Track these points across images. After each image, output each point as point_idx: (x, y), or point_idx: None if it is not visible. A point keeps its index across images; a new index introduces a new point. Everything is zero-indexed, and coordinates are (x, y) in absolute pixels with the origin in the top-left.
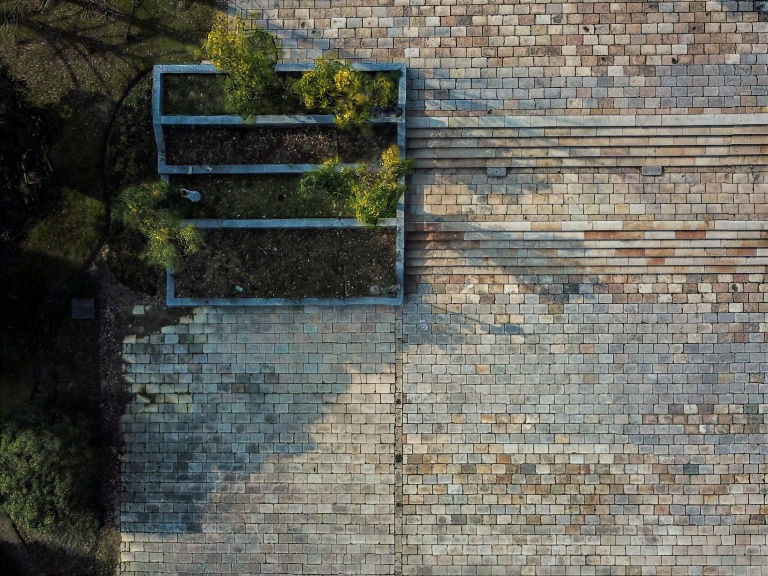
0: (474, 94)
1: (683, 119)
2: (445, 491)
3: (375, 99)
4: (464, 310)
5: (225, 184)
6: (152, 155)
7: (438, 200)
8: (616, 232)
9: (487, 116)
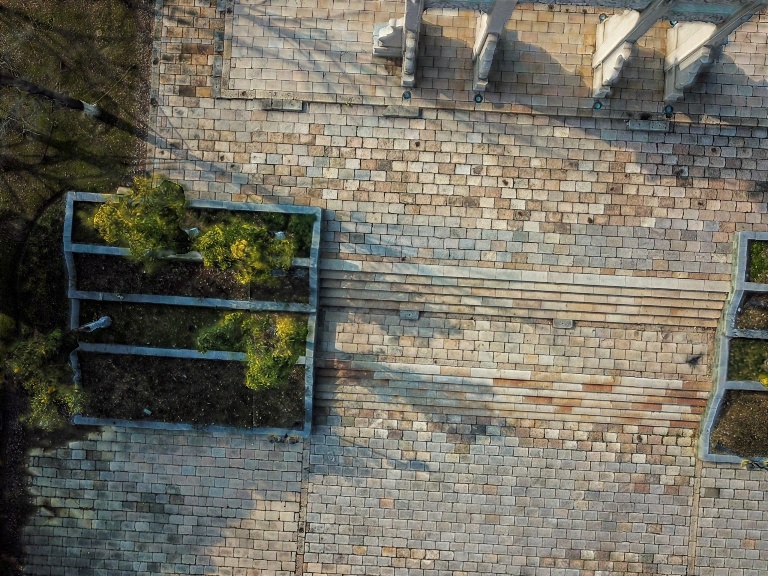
0: (389, 240)
1: (595, 279)
2: None
3: (278, 260)
4: (372, 444)
5: (137, 311)
6: (64, 278)
7: (350, 338)
8: (524, 381)
9: (401, 263)
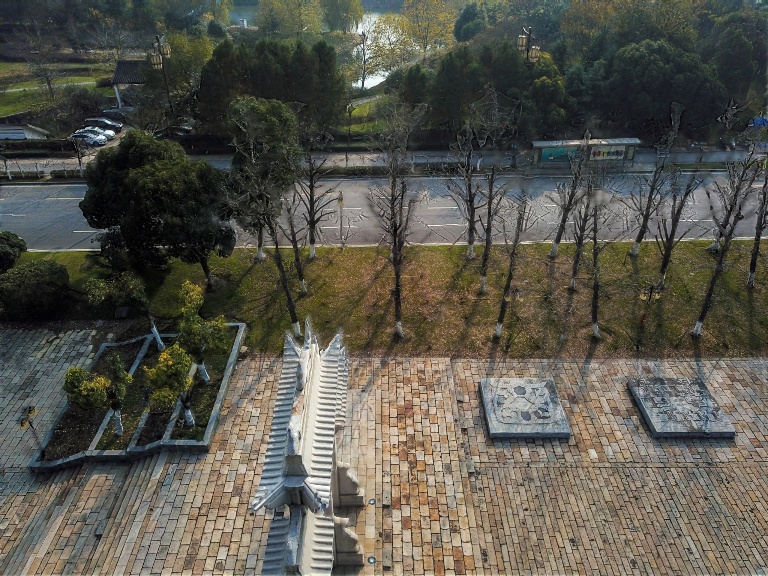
0: (171, 497)
1: None
2: None
3: None
4: None
5: None
6: None
7: None
8: None
9: (149, 508)
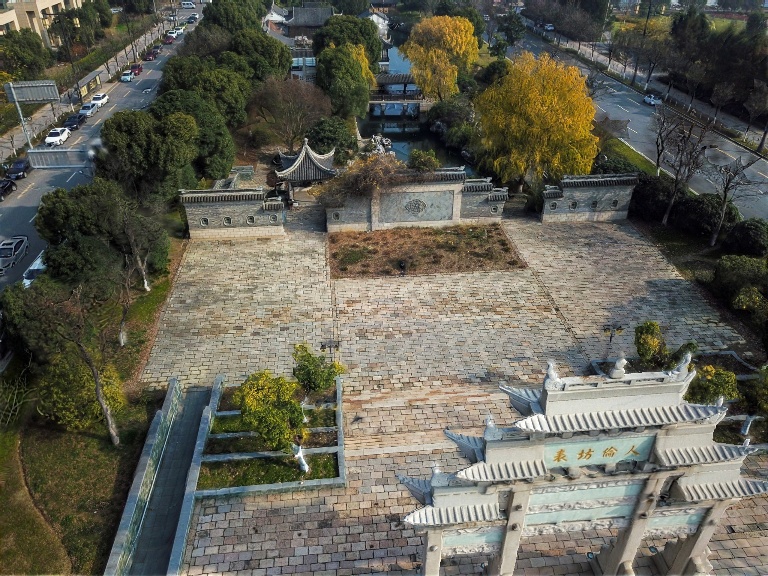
0: None
1: (446, 446)
2: None
3: None
4: None
5: None
6: None
7: None
8: None
9: None
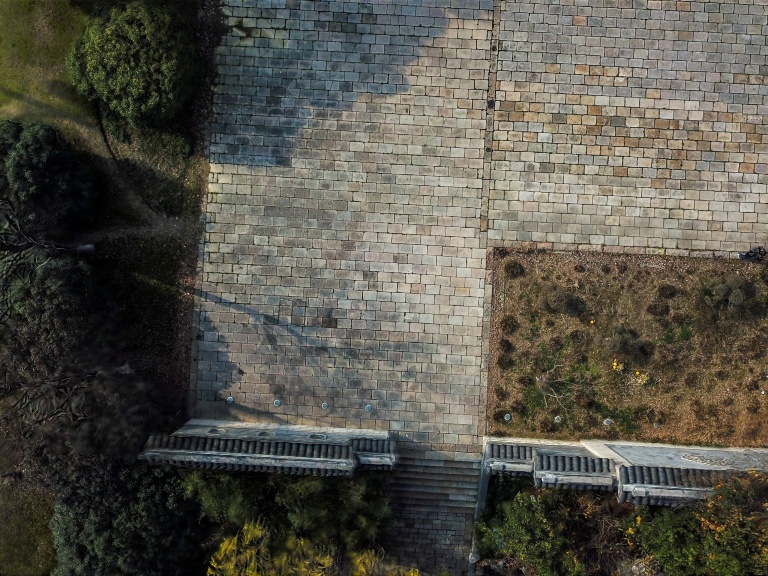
0: None
1: None
2: (535, 139)
3: None
4: None
5: None
6: None
7: None
8: None
9: None
